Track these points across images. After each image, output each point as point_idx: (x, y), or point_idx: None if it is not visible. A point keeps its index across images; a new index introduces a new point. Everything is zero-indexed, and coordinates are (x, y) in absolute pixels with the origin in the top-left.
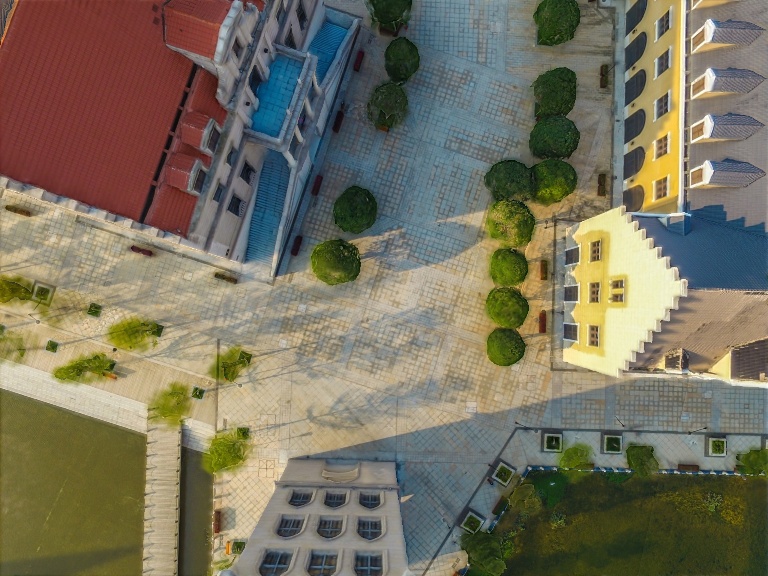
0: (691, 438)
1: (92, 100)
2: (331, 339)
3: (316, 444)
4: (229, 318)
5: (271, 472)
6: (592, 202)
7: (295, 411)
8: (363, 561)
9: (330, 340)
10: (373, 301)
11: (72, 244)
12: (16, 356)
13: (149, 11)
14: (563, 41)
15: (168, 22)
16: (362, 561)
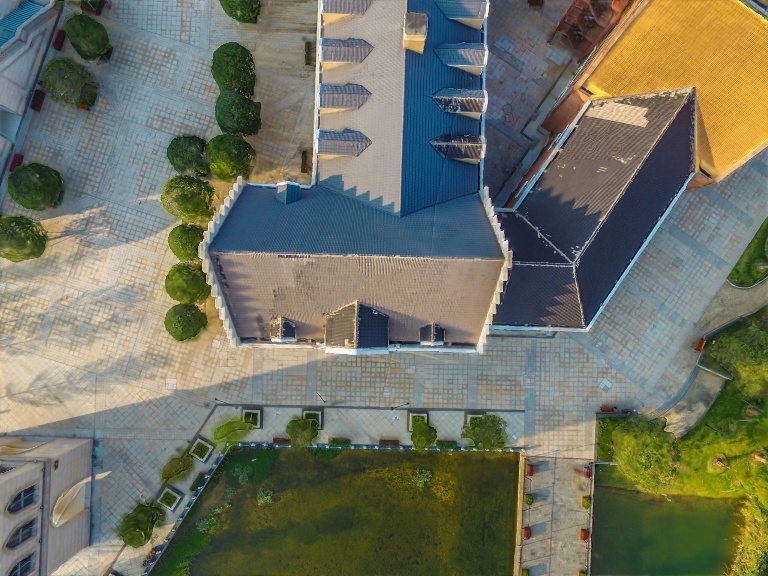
0: (393, 414)
1: None
2: (30, 317)
3: (14, 421)
4: None
5: None
6: (296, 179)
7: None
8: None
9: (29, 318)
10: (73, 279)
11: None
12: None
13: None
14: (246, 17)
15: None
16: None
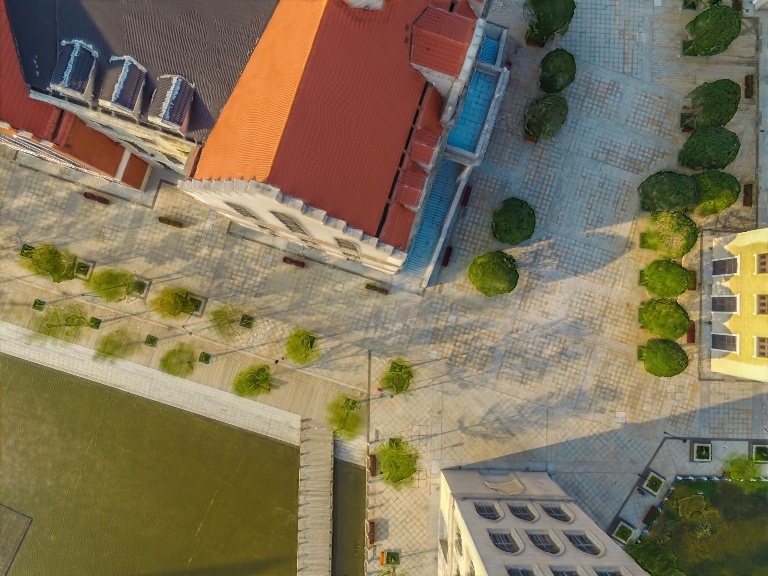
0: None
1: (355, 120)
2: (481, 350)
3: (468, 454)
4: (380, 329)
5: (423, 483)
6: (738, 212)
7: (446, 422)
8: None
9: (480, 351)
10: (522, 312)
11: (223, 255)
12: (169, 368)
13: (403, 30)
14: (718, 52)
15: (416, 41)
16: None
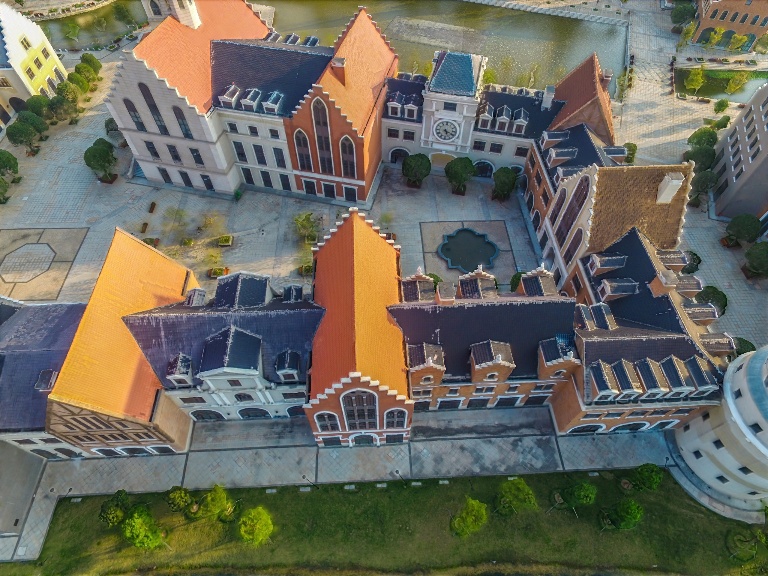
0: None
1: None
2: None
3: None
4: None
5: None
6: None
7: None
8: None
9: None
10: None
11: None
12: None
13: None
14: None
15: None
16: None
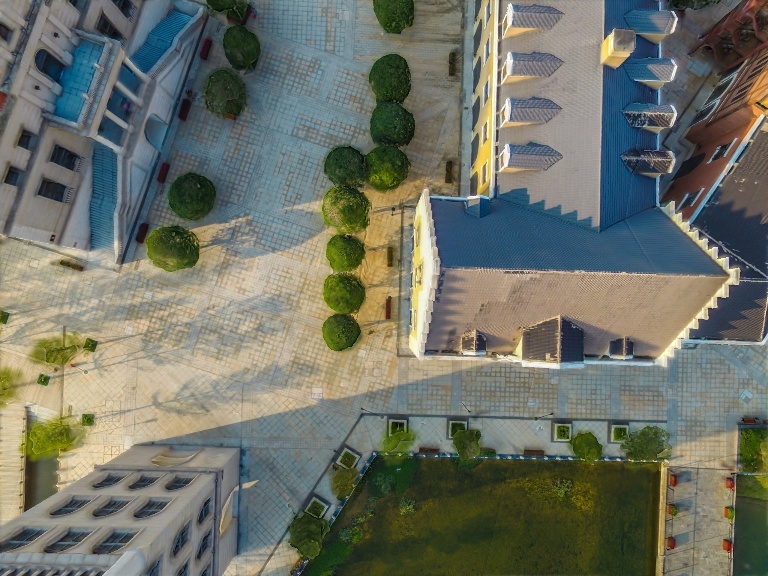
0: (537, 424)
1: None
2: (177, 326)
3: (161, 430)
4: (75, 305)
5: None
6: (440, 189)
7: (140, 397)
8: (117, 538)
9: (176, 327)
10: (219, 288)
11: None
12: None
13: None
14: (401, 28)
15: None
16: (116, 538)
